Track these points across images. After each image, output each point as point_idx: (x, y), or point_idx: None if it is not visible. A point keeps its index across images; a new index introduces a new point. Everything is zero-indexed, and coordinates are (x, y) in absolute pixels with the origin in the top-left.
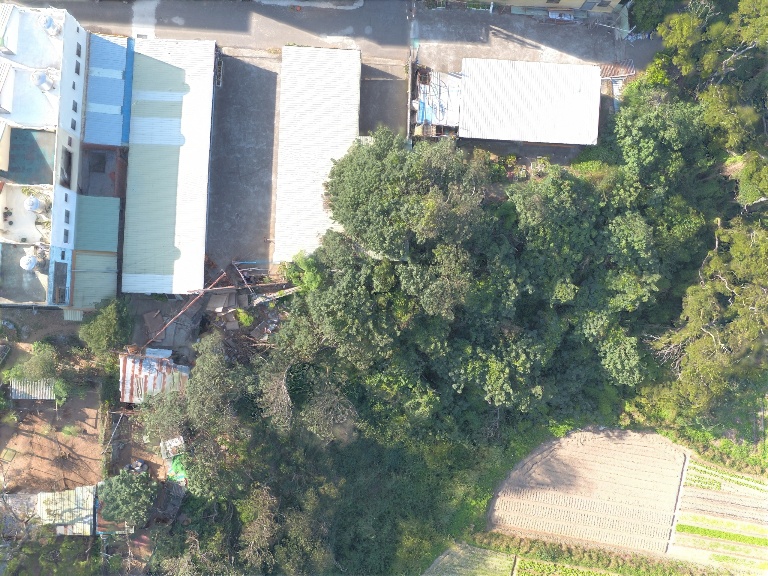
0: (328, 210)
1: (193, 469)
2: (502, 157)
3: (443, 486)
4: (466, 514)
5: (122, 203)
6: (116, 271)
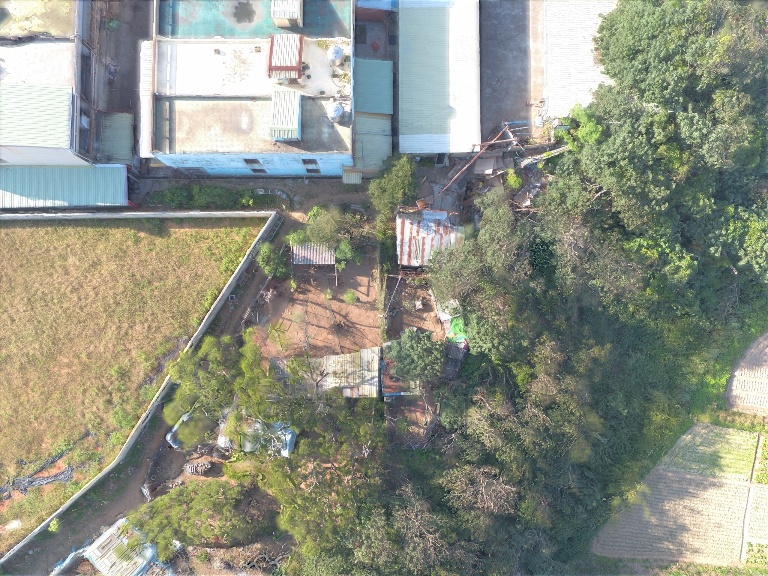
0: (599, 65)
1: (484, 322)
2: (761, 11)
3: (679, 366)
4: (706, 393)
5: (395, 66)
6: (391, 134)
